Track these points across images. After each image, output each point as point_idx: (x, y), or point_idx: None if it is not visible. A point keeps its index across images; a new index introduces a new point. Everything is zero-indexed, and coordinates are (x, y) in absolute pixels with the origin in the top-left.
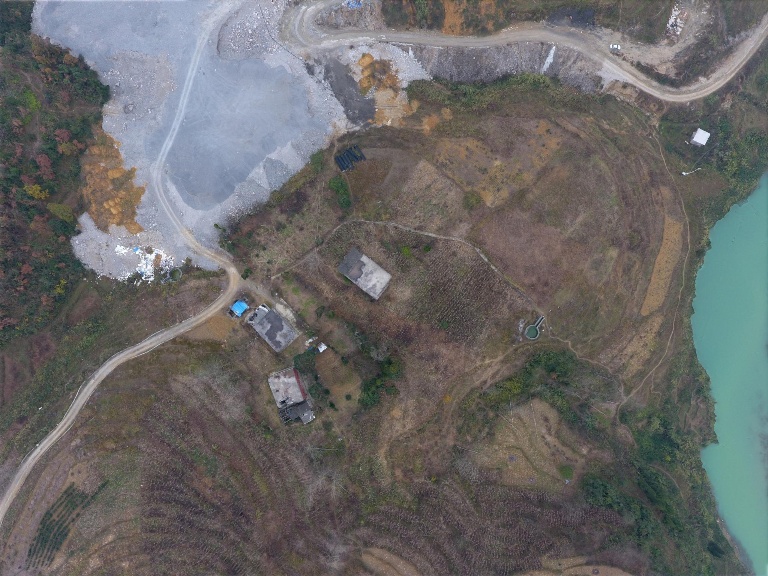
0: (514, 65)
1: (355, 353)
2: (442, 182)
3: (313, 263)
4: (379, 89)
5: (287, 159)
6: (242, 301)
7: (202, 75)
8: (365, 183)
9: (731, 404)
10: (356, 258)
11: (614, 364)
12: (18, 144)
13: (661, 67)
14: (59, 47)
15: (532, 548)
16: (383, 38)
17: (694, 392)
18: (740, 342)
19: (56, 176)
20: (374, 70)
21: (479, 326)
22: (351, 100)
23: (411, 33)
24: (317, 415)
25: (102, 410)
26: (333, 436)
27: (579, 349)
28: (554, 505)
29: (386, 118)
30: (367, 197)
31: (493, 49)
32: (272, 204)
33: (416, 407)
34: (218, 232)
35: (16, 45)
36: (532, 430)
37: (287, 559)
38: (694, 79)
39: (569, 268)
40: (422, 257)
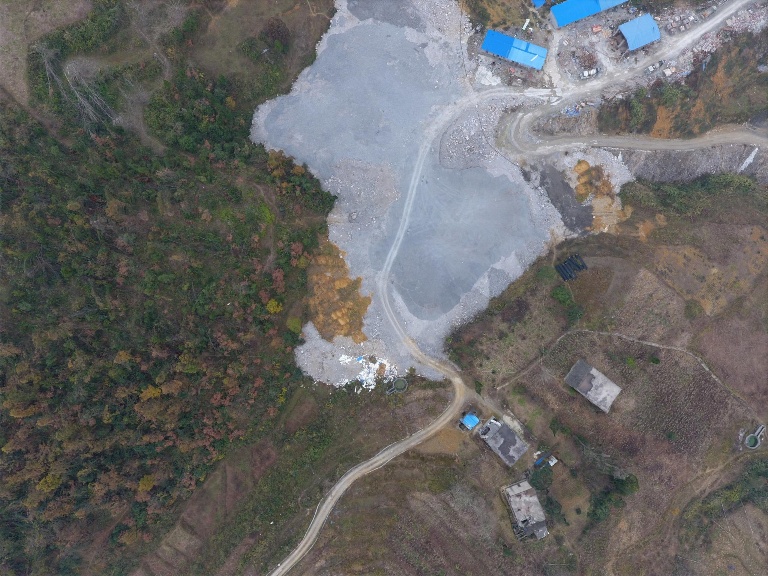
0: (714, 165)
1: (587, 467)
2: (663, 291)
3: (539, 374)
4: (597, 196)
5: (510, 268)
6: (473, 414)
7: (425, 184)
8: (589, 293)
9: None
10: (586, 371)
11: None
12: (256, 259)
13: None
14: (283, 155)
15: None
16: (595, 143)
17: None
18: None
19: (285, 287)
20: (591, 177)
21: (702, 436)
22: (568, 207)
23: (621, 137)
24: (549, 530)
25: (345, 530)
26: (565, 551)
27: None
28: None
29: (603, 225)
30: (591, 307)
31: (698, 152)
32: (492, 312)
33: (642, 519)
34: (442, 342)
35: (245, 156)
36: (747, 537)
37: None
38: None
39: None
40: (646, 367)
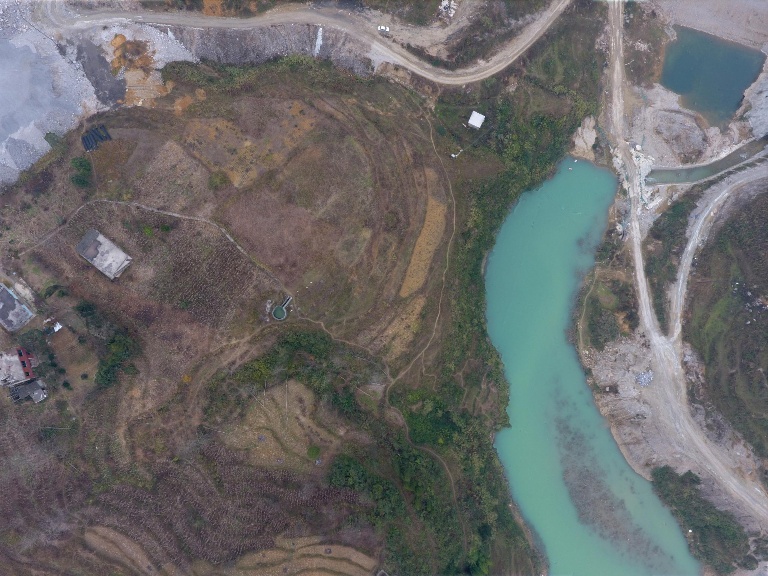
0: (283, 47)
1: None
2: (188, 162)
3: (54, 243)
4: (129, 69)
5: (31, 139)
6: None
7: None
8: (108, 163)
9: (529, 389)
10: (92, 237)
11: (374, 346)
12: None
13: (432, 49)
14: None
15: (268, 528)
16: (140, 19)
17: (485, 376)
18: (540, 327)
19: None
20: (125, 50)
21: (223, 306)
22: (102, 80)
23: (170, 14)
24: (51, 394)
25: None
26: (67, 415)
27: (334, 330)
28: (299, 485)
29: (137, 98)
30: (109, 177)
31: (257, 30)
32: (19, 184)
33: (157, 387)
34: None
35: None
36: (285, 411)
37: (3, 537)
38: (472, 62)
39: (319, 249)
40: (165, 237)
